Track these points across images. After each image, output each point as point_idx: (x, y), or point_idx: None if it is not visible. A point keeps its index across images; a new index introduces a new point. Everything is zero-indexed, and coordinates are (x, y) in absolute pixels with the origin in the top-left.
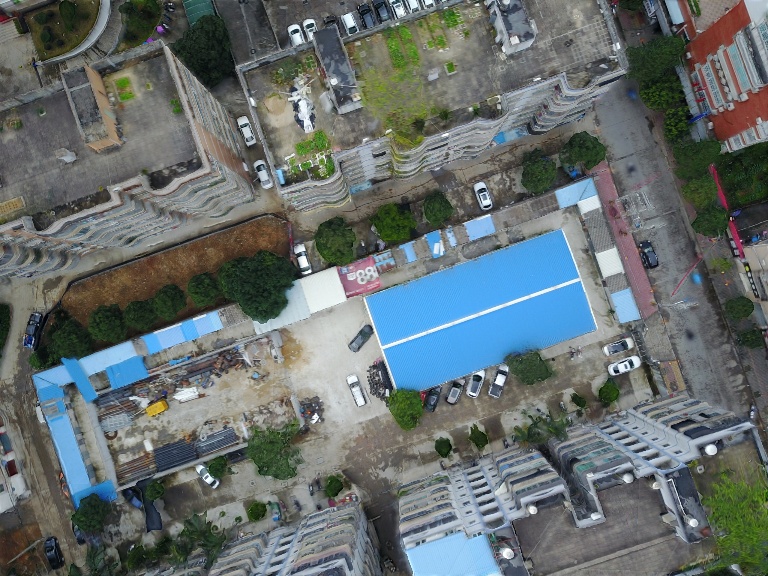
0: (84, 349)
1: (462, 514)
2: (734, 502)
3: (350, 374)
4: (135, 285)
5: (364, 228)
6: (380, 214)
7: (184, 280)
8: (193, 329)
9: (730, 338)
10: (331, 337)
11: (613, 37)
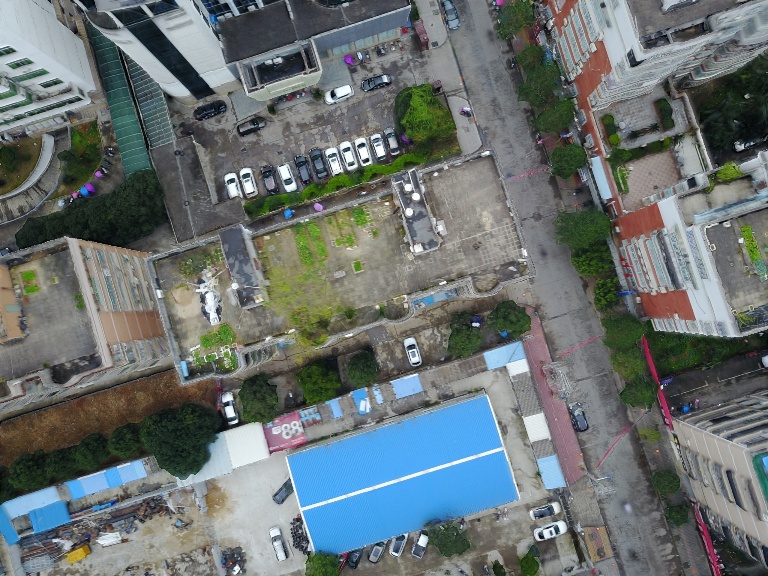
0: (6, 496)
1: None
2: None
3: (273, 526)
4: (64, 426)
5: (293, 378)
6: (303, 375)
7: (112, 423)
8: (117, 477)
9: (660, 505)
10: (256, 487)
11: (522, 241)
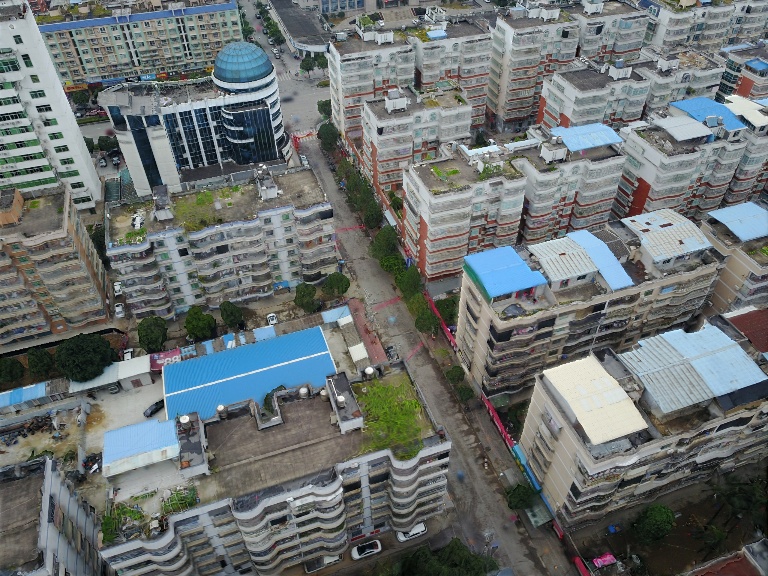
0: None
1: None
2: (382, 398)
3: None
4: None
5: (182, 341)
6: None
7: None
8: (20, 395)
9: (461, 409)
10: (132, 409)
11: None
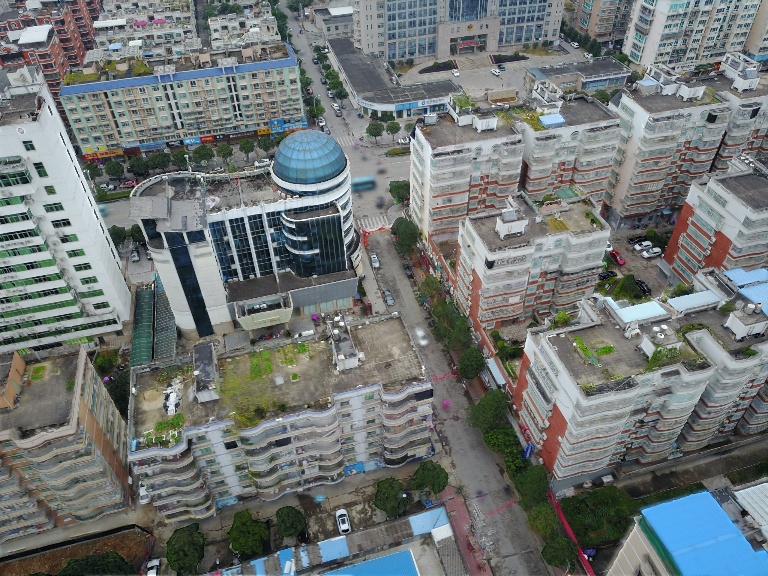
0: None
1: None
2: None
3: None
4: None
5: (224, 547)
6: (234, 521)
7: None
8: None
9: None
10: None
11: (421, 364)
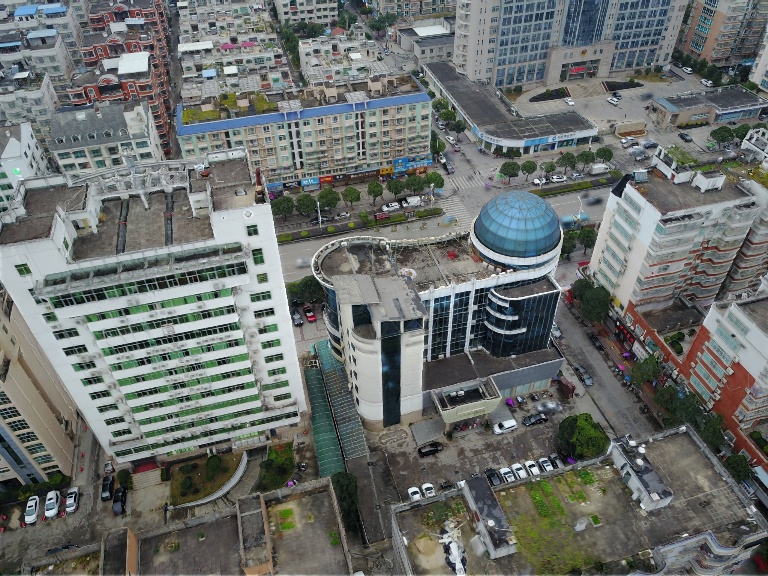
0: None
1: None
2: None
3: None
4: None
5: None
6: None
7: None
8: None
9: None
10: None
11: (744, 501)
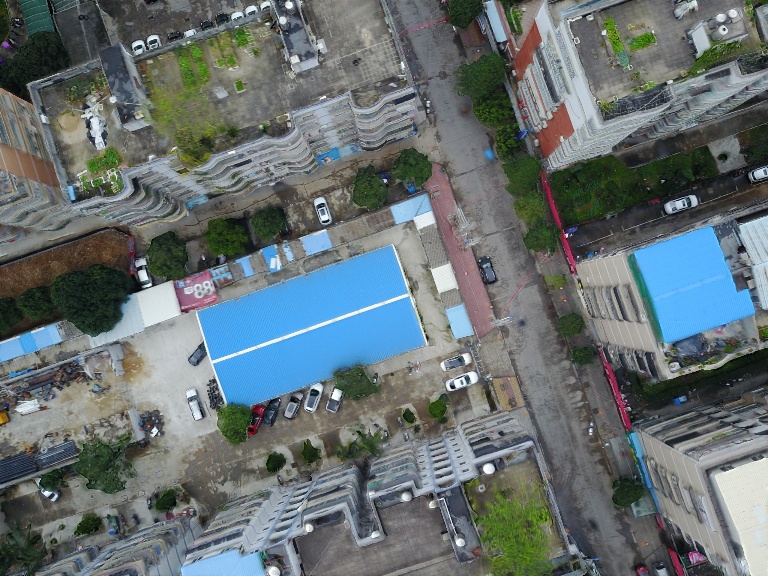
0: None
1: (257, 531)
2: (508, 522)
3: (190, 388)
4: None
5: (206, 242)
6: (209, 229)
7: None
8: (31, 342)
9: (569, 354)
10: (172, 351)
11: (400, 56)
